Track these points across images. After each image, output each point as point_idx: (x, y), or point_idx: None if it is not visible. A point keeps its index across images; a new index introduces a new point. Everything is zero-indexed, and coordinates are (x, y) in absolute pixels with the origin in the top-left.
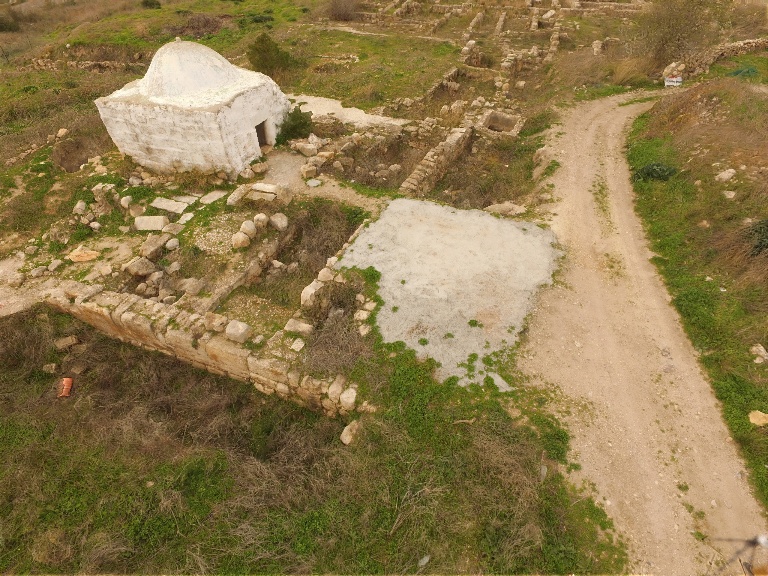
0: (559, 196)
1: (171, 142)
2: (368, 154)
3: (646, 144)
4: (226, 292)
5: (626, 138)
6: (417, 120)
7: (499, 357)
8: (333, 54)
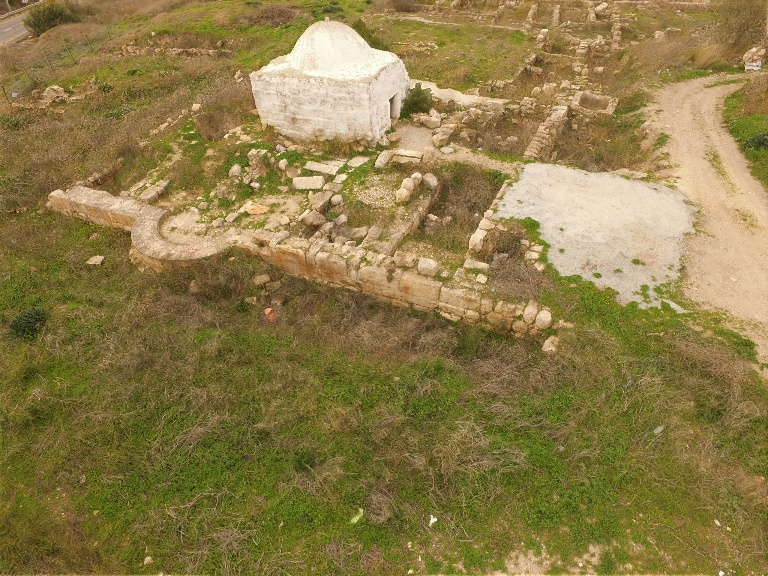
0: (676, 163)
1: (318, 112)
2: (484, 127)
3: (747, 119)
4: (401, 238)
5: (722, 115)
6: None
7: (667, 288)
8: (411, 42)
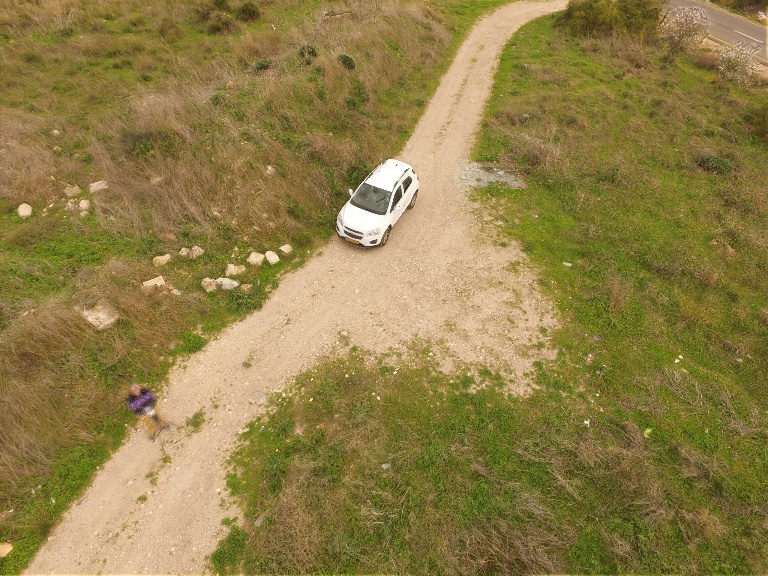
0: None
1: None
2: None
3: None
4: None
5: None
6: None
7: None
8: None
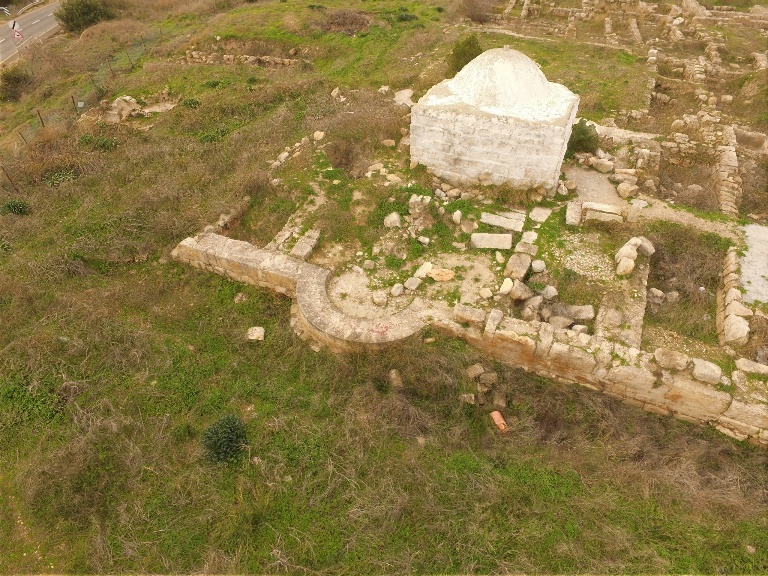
0: None
1: (492, 154)
2: None
3: None
4: (642, 324)
5: None
6: (660, 134)
7: None
8: None
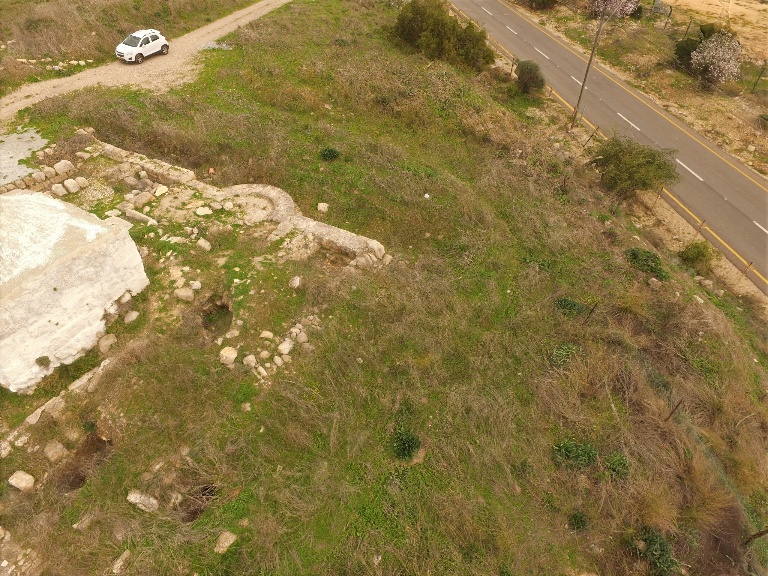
0: None
1: None
2: None
3: None
4: None
5: None
6: None
7: None
8: None
